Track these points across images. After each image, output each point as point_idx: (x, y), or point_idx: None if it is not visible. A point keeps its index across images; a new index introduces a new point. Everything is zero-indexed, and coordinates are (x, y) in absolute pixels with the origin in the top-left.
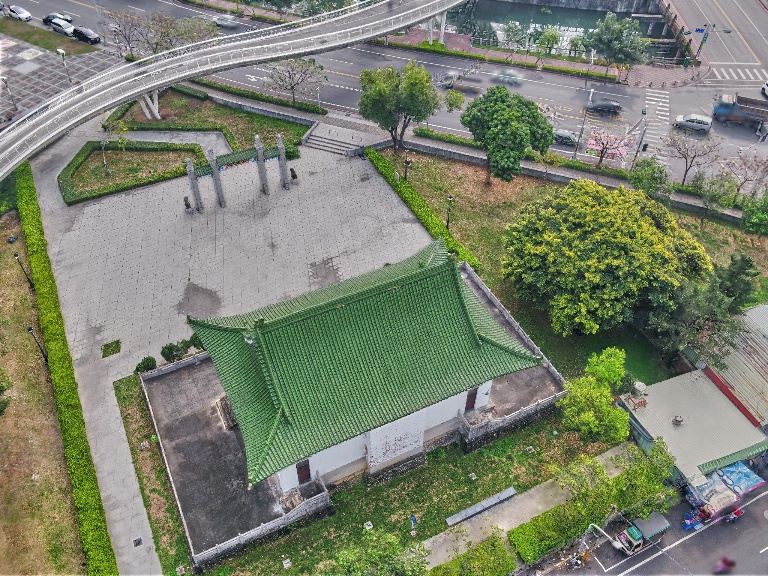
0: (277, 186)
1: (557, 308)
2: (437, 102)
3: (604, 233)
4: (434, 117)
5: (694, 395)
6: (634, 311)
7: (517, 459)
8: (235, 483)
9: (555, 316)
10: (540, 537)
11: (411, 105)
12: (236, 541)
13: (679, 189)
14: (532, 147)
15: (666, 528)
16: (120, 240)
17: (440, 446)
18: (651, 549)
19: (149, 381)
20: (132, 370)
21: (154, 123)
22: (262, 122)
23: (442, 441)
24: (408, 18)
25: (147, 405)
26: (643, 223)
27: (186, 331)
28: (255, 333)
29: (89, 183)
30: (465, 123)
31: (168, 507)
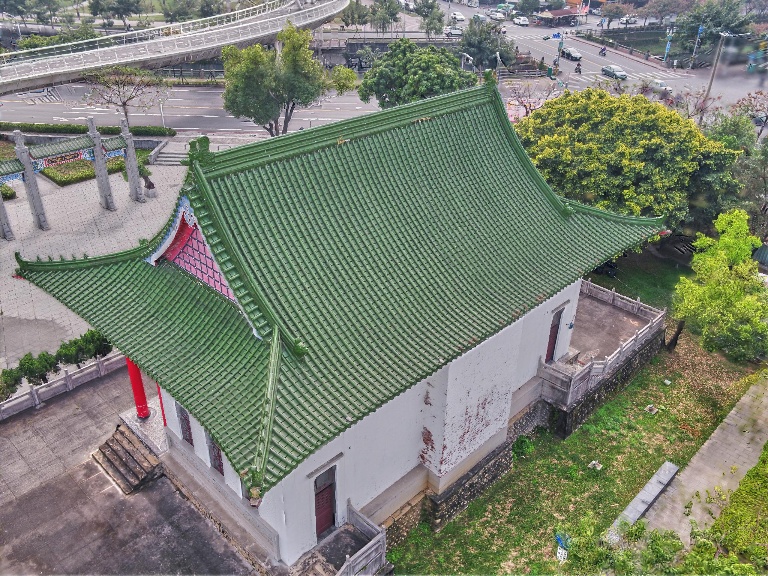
0: (126, 201)
1: None
2: (324, 80)
3: (620, 118)
4: None
5: None
6: None
7: (642, 426)
8: None
9: None
10: None
11: (295, 80)
12: None
13: None
14: None
15: None
16: None
17: (521, 435)
18: None
19: None
20: None
21: None
22: None
23: (522, 424)
24: (256, 32)
25: None
26: None
27: None
28: (191, 179)
29: None
30: (370, 87)
31: None
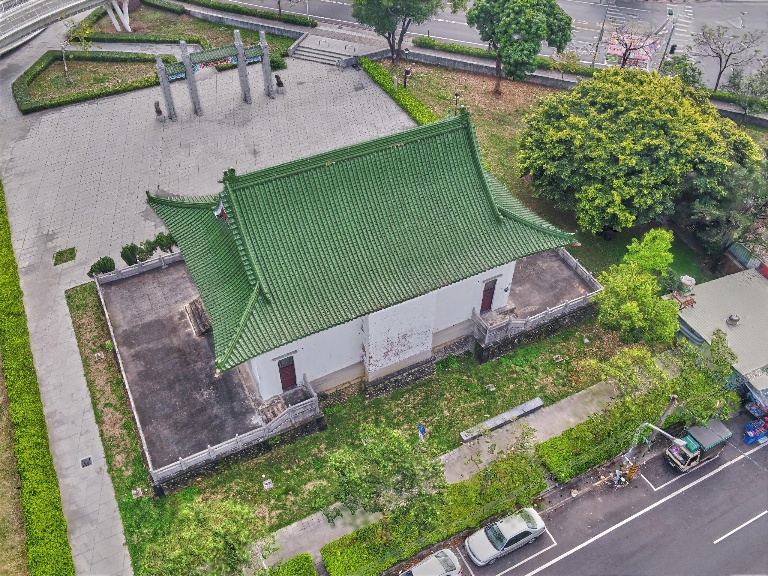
0: (261, 95)
1: (585, 200)
2: (440, 0)
3: (640, 112)
4: (435, 28)
5: (749, 295)
6: (675, 203)
7: (542, 369)
8: (205, 393)
9: (582, 211)
10: (575, 451)
11: (411, 1)
12: (205, 455)
13: (711, 95)
14: (548, 43)
15: (728, 438)
16: (81, 148)
17: (451, 355)
18: (708, 465)
19: (106, 285)
20: (88, 278)
21: (124, 34)
22: (245, 35)
23: (453, 348)
24: None
25: (102, 310)
26: (685, 100)
27: (153, 238)
28: None
29: (48, 92)
30: (472, 18)
31: (125, 423)
